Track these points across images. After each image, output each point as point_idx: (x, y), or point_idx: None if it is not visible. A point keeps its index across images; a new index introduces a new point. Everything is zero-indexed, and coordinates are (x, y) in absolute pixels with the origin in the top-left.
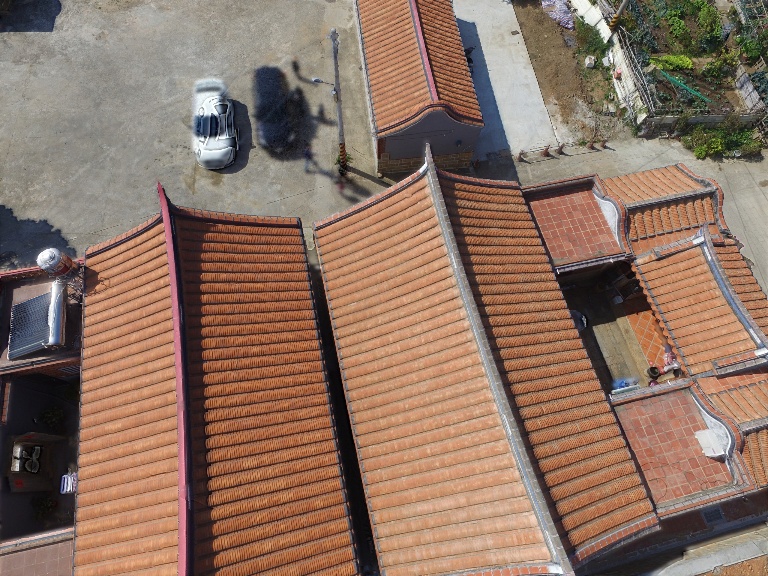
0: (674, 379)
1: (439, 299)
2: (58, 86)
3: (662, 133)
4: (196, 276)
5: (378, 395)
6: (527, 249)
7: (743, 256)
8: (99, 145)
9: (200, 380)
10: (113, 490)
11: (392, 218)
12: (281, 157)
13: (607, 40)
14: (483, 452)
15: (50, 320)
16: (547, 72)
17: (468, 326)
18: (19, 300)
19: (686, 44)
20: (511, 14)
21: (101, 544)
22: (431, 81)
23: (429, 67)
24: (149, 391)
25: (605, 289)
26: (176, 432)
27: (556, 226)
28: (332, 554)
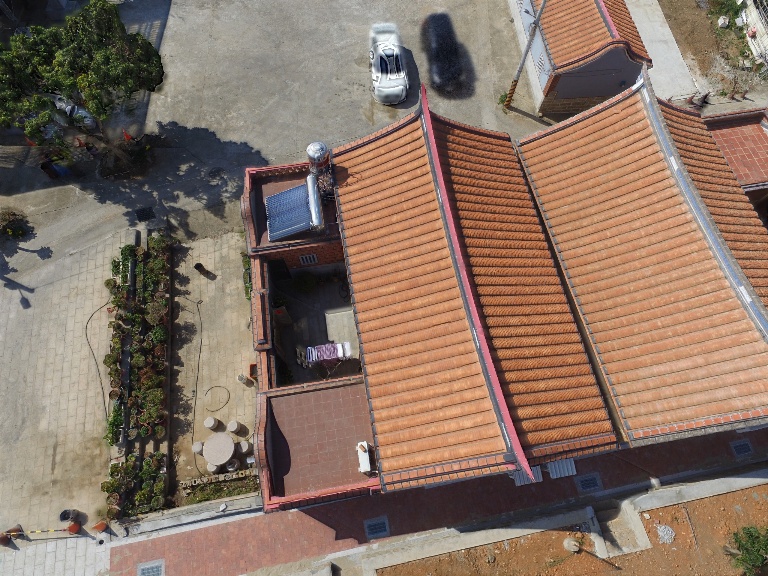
0: None
1: (657, 198)
2: (240, 29)
3: None
4: (447, 168)
5: (600, 281)
6: (718, 166)
7: None
8: (284, 80)
9: (465, 251)
10: (398, 338)
11: (601, 132)
12: (448, 96)
13: (741, 1)
14: (718, 320)
15: (312, 205)
16: (682, 30)
17: (691, 218)
18: (268, 194)
19: None
20: None
21: (394, 380)
22: (610, 22)
23: (606, 10)
24: (419, 260)
25: None
26: (454, 290)
27: (731, 153)
28: (588, 400)
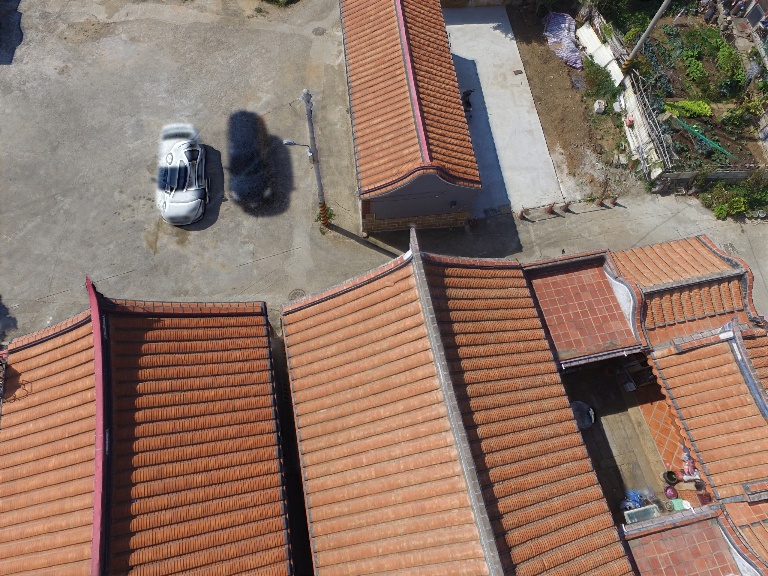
0: (695, 492)
1: (422, 417)
2: (12, 126)
3: (678, 189)
4: (131, 388)
5: (347, 531)
6: (528, 345)
7: None
8: (53, 195)
9: (126, 527)
10: None
11: (371, 309)
12: (255, 212)
13: (618, 83)
14: None
15: None
16: (552, 117)
17: (456, 456)
18: None
19: (704, 88)
20: (514, 51)
21: None
22: (422, 138)
23: (420, 121)
24: (64, 538)
25: (615, 373)
26: None
27: (561, 310)
28: None
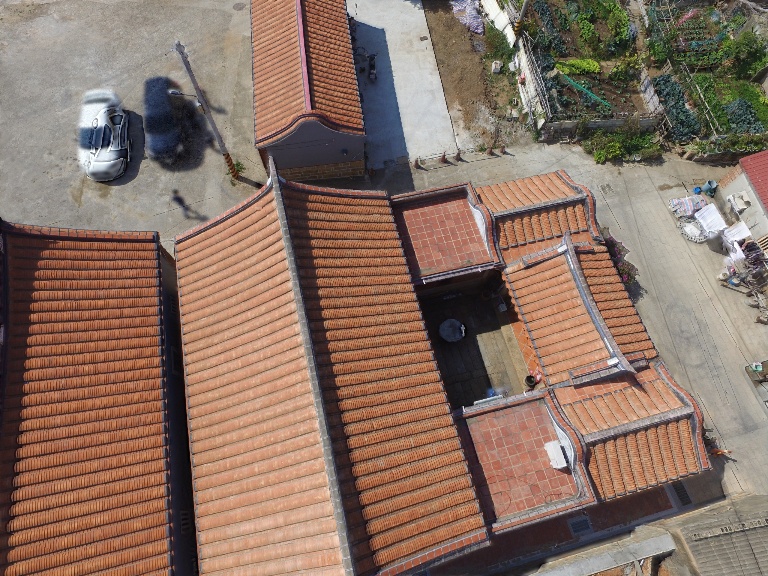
0: None
1: (279, 314)
2: None
3: (563, 138)
4: (27, 295)
5: (217, 412)
6: (385, 260)
7: (628, 262)
8: None
9: (18, 402)
10: None
11: (244, 231)
12: (172, 168)
13: (512, 45)
14: (302, 470)
15: None
16: (453, 78)
17: (301, 341)
18: None
19: (594, 48)
20: (421, 20)
21: None
22: (306, 91)
23: (306, 76)
24: None
25: (491, 297)
26: None
27: (427, 235)
28: None
